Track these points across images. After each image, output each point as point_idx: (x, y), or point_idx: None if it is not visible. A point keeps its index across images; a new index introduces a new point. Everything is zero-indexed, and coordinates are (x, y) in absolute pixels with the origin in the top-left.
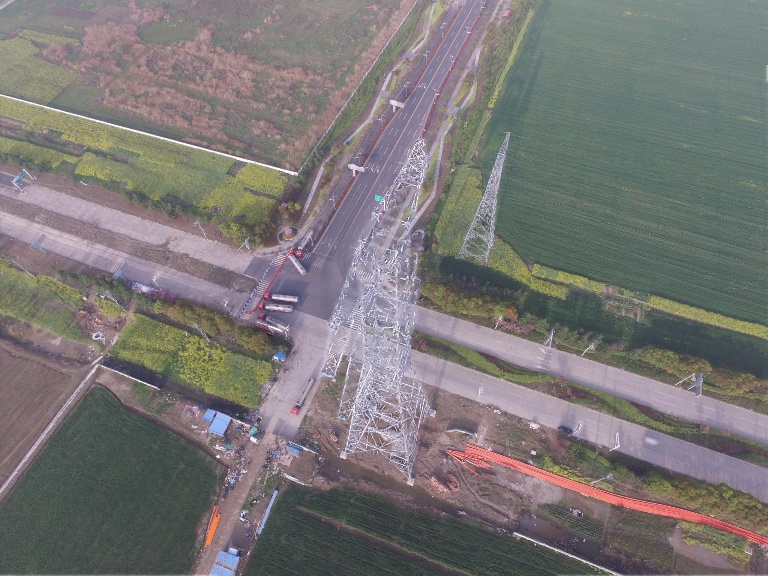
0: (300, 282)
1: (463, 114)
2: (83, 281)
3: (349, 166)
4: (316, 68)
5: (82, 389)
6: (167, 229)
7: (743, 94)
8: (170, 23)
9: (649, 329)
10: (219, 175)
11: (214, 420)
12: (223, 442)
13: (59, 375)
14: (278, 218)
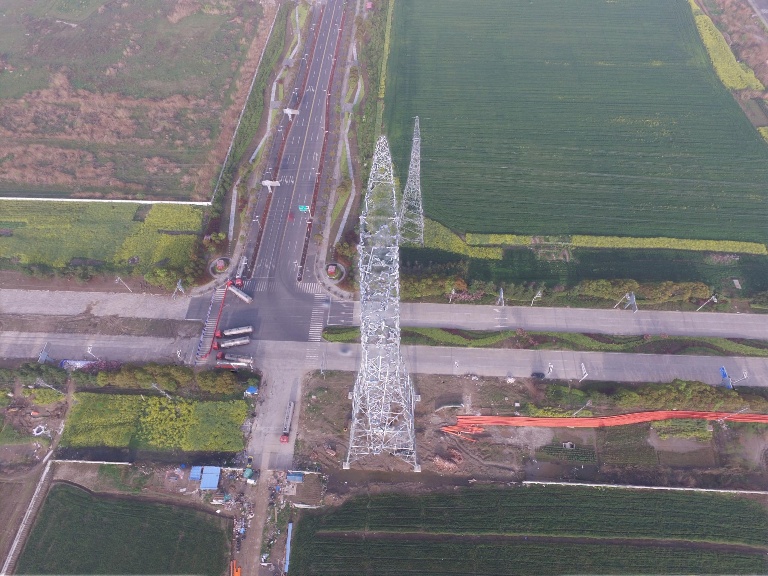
0: (248, 311)
1: (358, 109)
2: (2, 376)
3: (263, 183)
4: (196, 92)
5: (40, 493)
6: (84, 295)
7: (592, 43)
8: (14, 74)
9: (579, 266)
10: (125, 224)
11: (203, 476)
12: (219, 495)
13: (6, 487)
14: (204, 253)
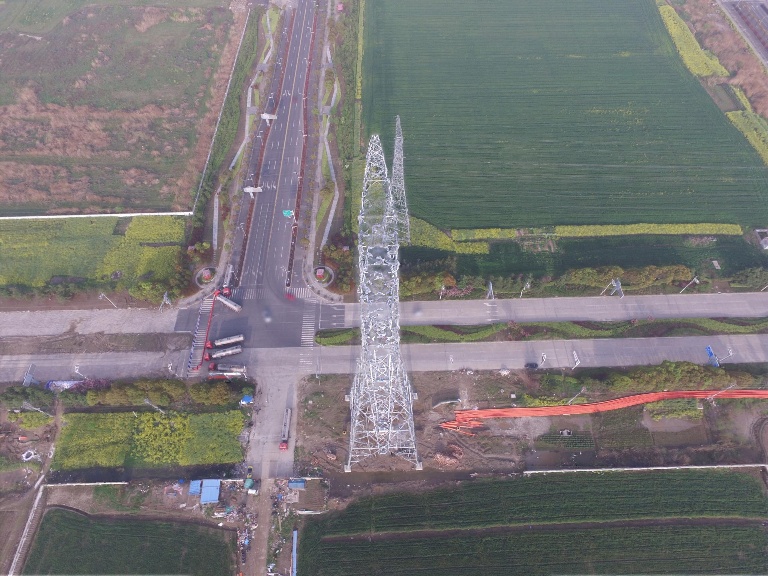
0: (238, 319)
1: (336, 111)
2: None
3: (245, 190)
4: (170, 101)
5: (33, 519)
6: (67, 313)
7: (562, 37)
8: None
9: (564, 255)
10: (105, 238)
11: (202, 490)
12: (221, 508)
13: None
14: (189, 263)
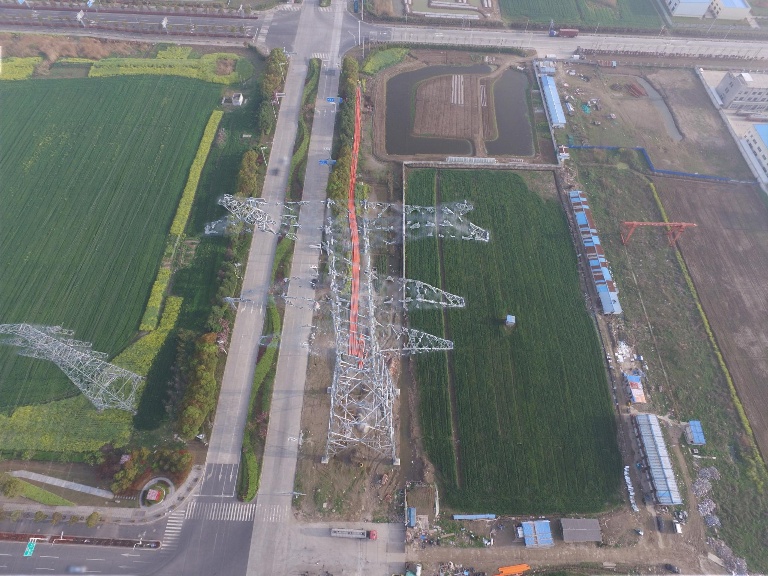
0: None
1: None
2: None
3: None
4: None
5: None
6: None
7: None
8: None
9: None
10: None
11: None
12: None
13: None
14: None
